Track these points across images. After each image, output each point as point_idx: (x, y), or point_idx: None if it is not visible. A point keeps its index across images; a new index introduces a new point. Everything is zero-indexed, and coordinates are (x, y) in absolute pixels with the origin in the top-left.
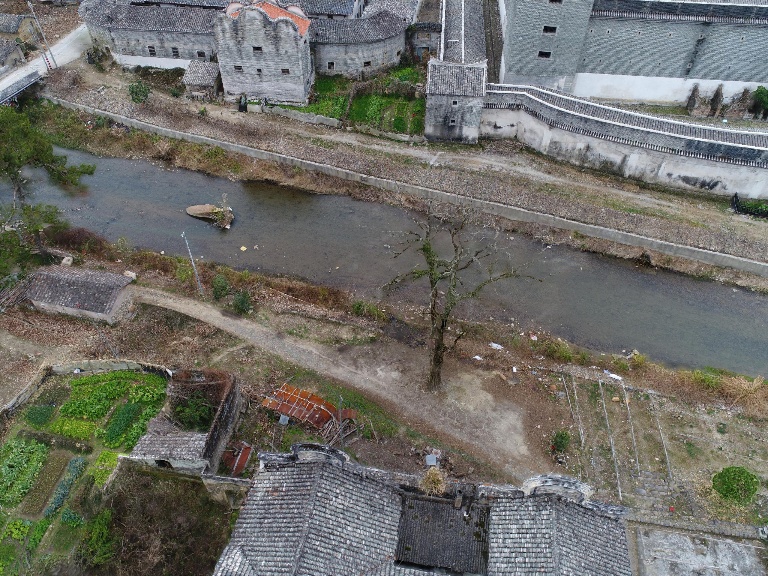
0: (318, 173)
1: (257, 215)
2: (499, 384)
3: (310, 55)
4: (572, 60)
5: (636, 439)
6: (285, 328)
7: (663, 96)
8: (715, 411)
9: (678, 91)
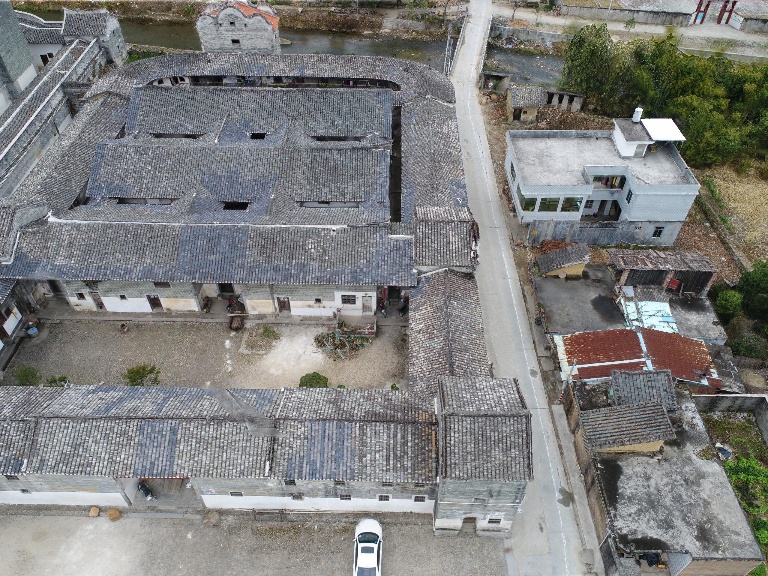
0: None
1: None
2: None
3: None
4: None
5: None
6: None
7: None
8: None
9: None
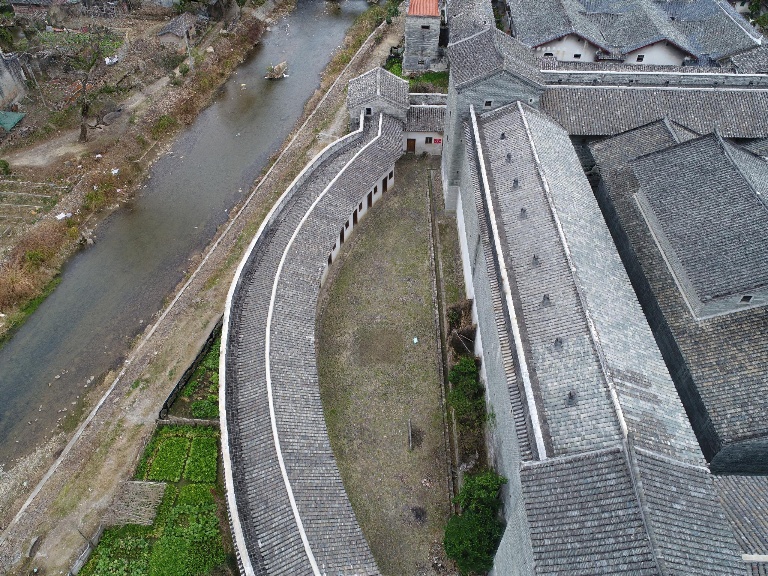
0: None
1: (280, 86)
2: (69, 158)
3: (441, 46)
4: None
5: (3, 212)
6: (153, 95)
7: None
8: (4, 255)
9: None
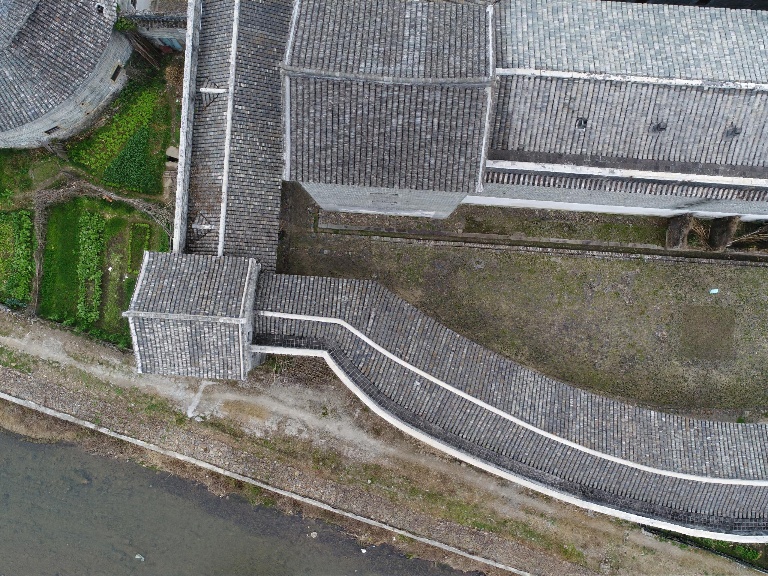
0: (22, 407)
1: None
2: None
3: None
4: (442, 207)
5: None
6: None
7: (627, 212)
8: None
9: (656, 212)
